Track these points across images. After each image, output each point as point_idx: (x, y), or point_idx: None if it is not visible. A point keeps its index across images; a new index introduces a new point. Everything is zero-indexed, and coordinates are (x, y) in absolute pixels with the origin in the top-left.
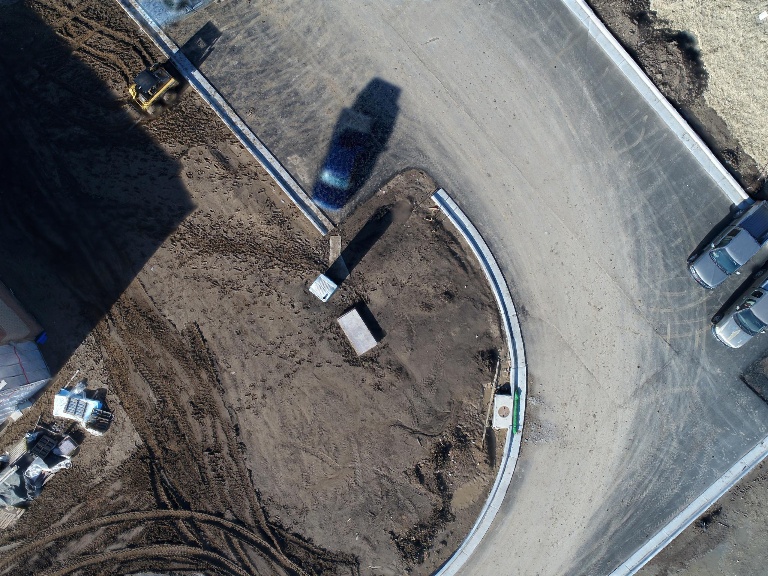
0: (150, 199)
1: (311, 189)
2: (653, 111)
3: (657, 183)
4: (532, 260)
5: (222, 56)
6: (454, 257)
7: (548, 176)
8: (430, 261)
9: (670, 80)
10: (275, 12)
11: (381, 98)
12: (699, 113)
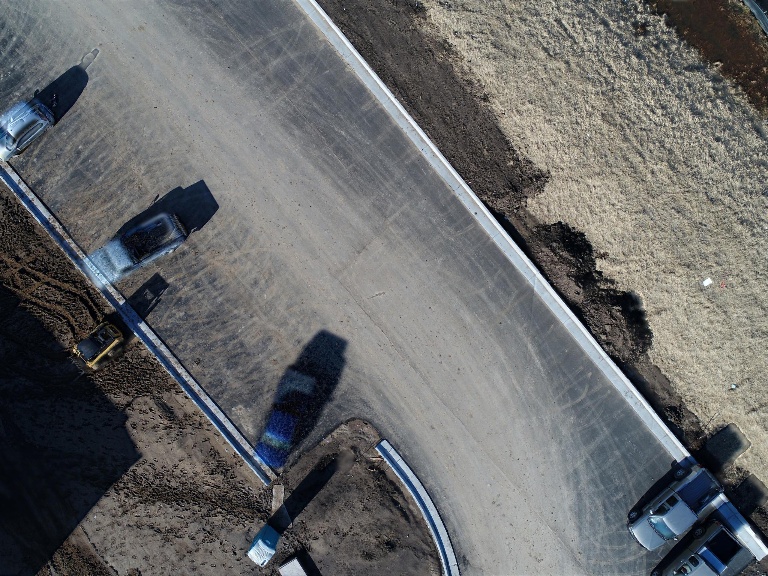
0: (94, 449)
1: (255, 439)
2: (597, 368)
3: (600, 439)
4: (474, 511)
5: (169, 307)
6: (396, 507)
7: (491, 430)
8: (372, 511)
9: (614, 341)
10: (222, 264)
11: (327, 350)
12: (643, 370)
